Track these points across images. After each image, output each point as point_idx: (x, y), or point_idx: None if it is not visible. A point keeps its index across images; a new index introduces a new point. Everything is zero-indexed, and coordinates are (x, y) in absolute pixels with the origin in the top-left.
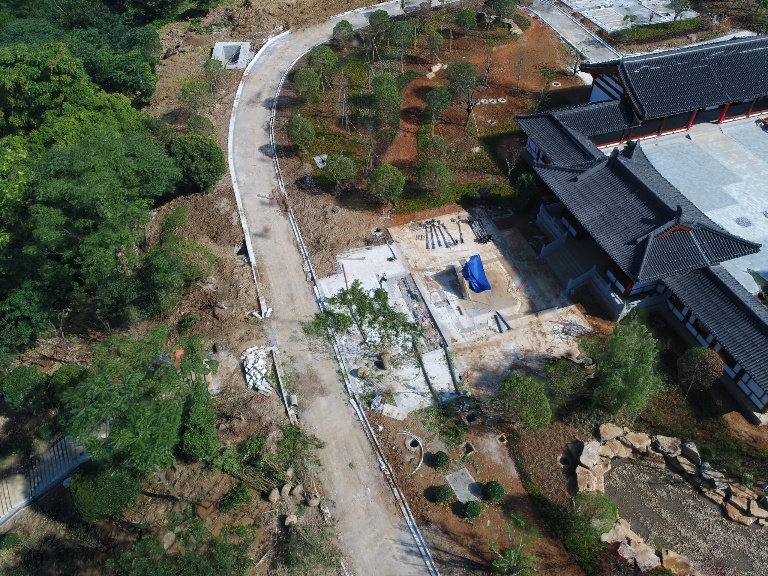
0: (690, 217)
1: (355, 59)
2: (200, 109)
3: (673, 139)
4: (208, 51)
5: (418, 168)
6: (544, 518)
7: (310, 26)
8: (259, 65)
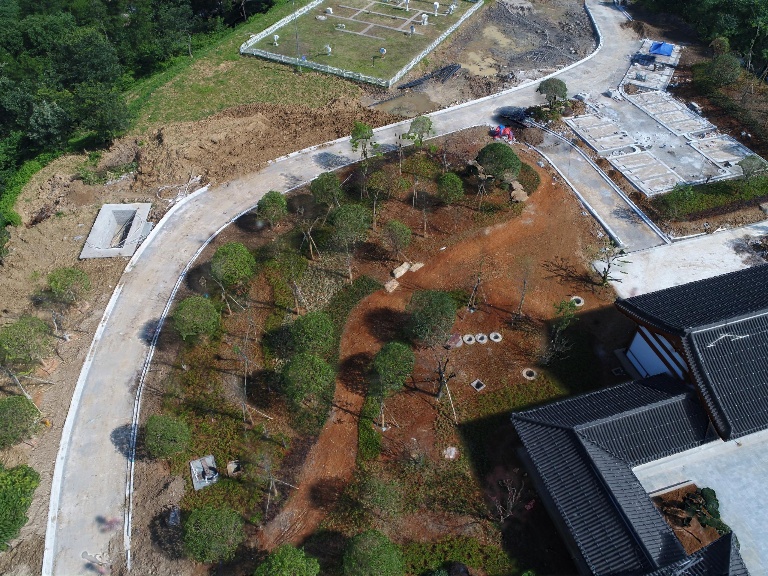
0: None
1: (287, 249)
2: (20, 373)
3: (764, 430)
4: (93, 215)
5: (353, 501)
6: None
7: (238, 177)
8: (152, 250)
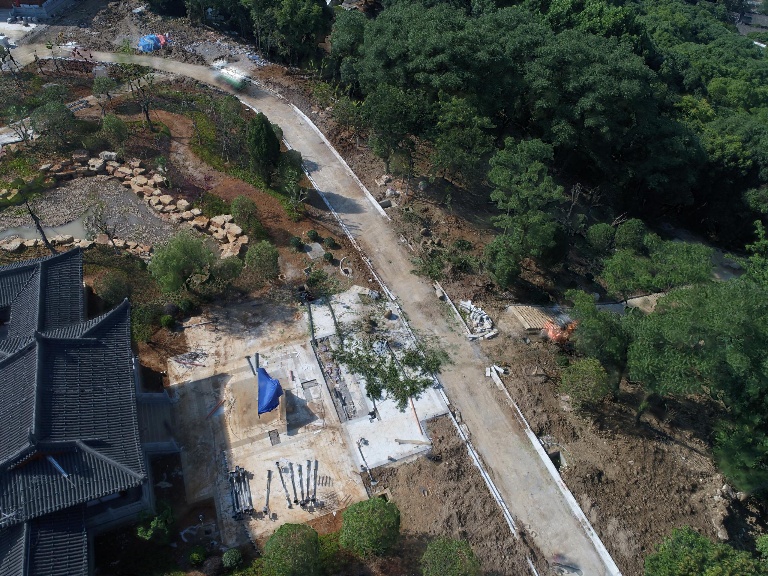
0: (22, 346)
1: None
2: None
3: None
4: None
5: None
6: (269, 235)
7: None
8: None
